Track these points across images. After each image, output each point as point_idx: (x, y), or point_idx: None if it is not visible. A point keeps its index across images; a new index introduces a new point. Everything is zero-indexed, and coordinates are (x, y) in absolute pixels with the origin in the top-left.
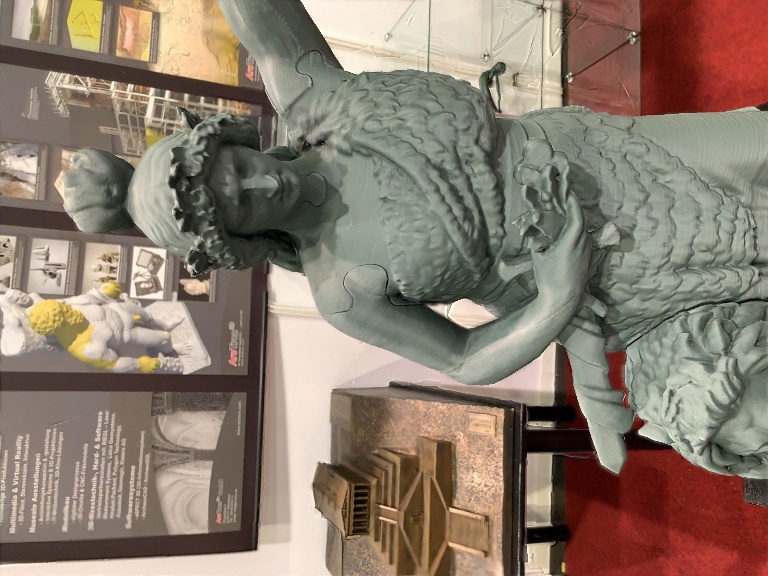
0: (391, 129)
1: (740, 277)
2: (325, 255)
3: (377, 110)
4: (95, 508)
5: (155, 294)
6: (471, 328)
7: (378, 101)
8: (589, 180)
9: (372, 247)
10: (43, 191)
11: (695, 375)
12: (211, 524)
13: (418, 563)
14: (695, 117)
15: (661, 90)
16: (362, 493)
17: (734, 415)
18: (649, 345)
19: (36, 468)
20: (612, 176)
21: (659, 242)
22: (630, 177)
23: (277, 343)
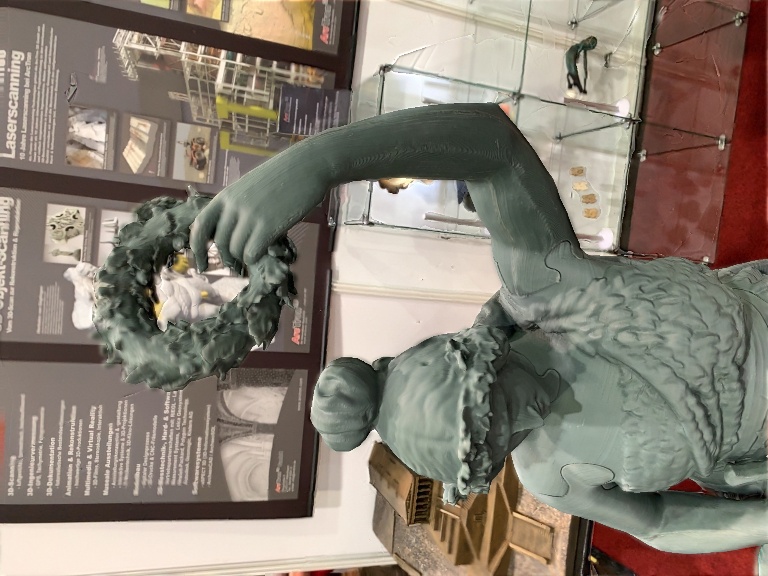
0: (649, 347)
1: None
2: (544, 441)
3: (634, 322)
4: (164, 475)
5: (222, 270)
6: (661, 491)
7: (635, 311)
8: None
9: (604, 451)
10: (111, 160)
11: None
12: (271, 492)
13: (477, 556)
14: None
15: (764, 85)
16: (425, 485)
17: None
18: None
19: (109, 437)
20: None
21: None
22: None
23: (338, 321)
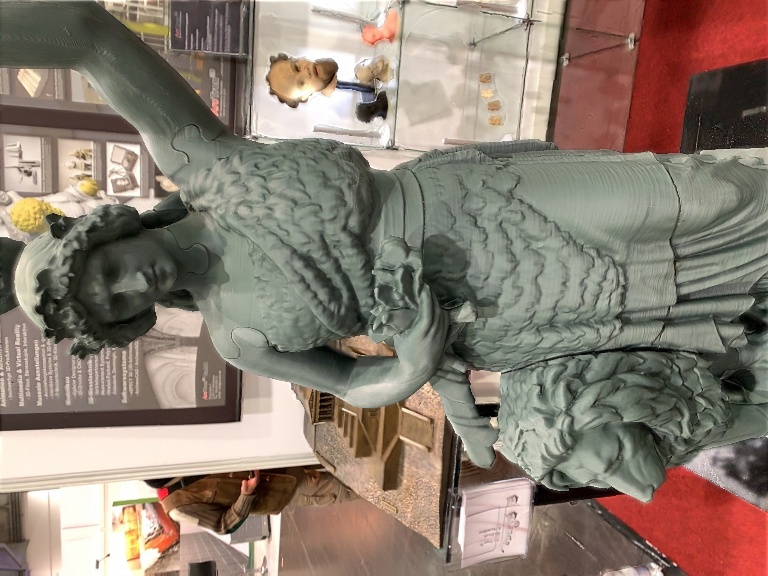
0: (260, 218)
1: (599, 334)
2: (214, 310)
3: (248, 197)
4: (93, 386)
5: (132, 191)
6: (359, 357)
7: (249, 186)
8: (458, 253)
9: (251, 315)
10: (7, 84)
11: (537, 427)
12: (198, 400)
13: (374, 449)
14: (581, 176)
15: None
16: None
17: (566, 460)
18: (513, 384)
19: (35, 352)
20: (482, 248)
21: (521, 309)
22: (501, 247)
23: None
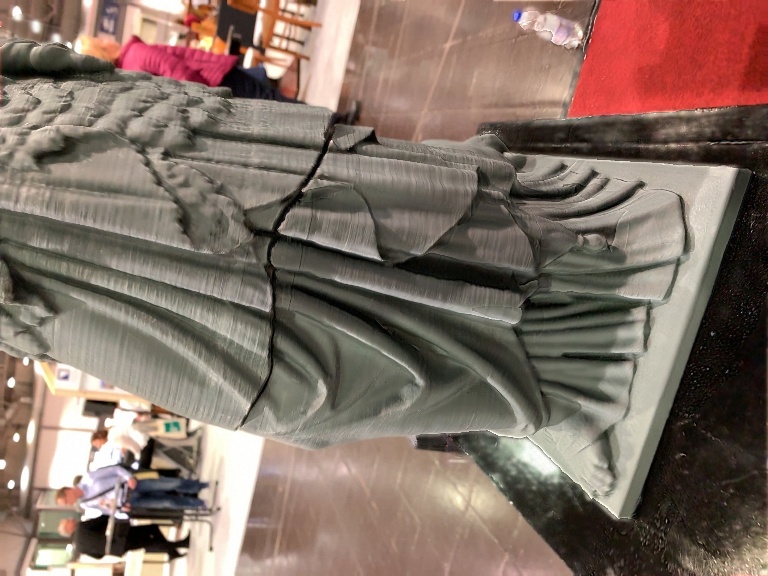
0: None
1: None
2: None
3: None
4: None
5: None
6: None
7: None
8: None
9: None
10: None
11: None
12: None
13: None
14: (127, 386)
15: None
16: None
17: None
18: None
19: None
20: None
21: None
22: None
23: None
